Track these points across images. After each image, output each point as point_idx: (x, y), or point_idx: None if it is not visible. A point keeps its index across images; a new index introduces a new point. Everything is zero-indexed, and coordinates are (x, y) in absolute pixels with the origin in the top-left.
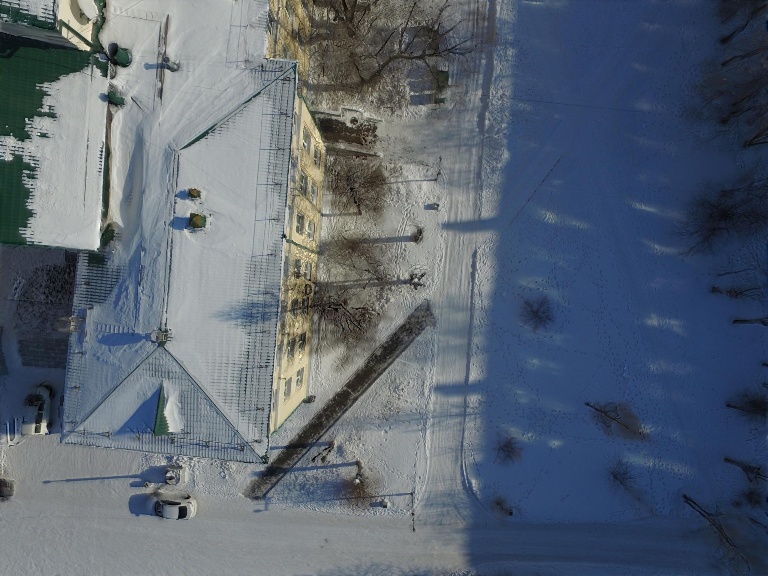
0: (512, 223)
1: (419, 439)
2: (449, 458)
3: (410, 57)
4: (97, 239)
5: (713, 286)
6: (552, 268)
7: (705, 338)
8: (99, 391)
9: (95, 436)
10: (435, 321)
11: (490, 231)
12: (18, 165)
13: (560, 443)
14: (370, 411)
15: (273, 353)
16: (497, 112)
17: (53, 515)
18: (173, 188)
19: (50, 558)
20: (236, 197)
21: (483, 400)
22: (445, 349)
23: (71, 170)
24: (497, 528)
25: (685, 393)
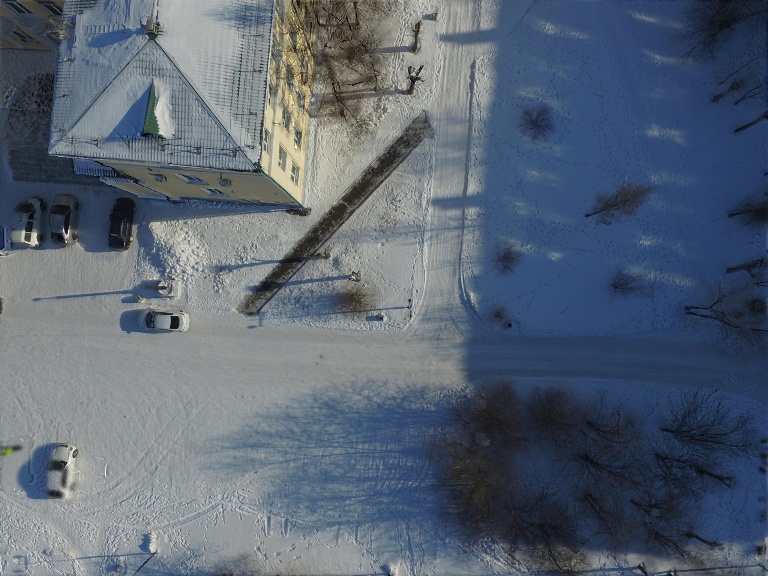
0: (511, 34)
1: (416, 251)
2: (447, 272)
3: None
4: None
5: (714, 95)
6: (551, 78)
7: (706, 148)
8: (88, 95)
9: (83, 145)
10: (433, 133)
11: (489, 42)
12: None
13: (560, 255)
14: (367, 223)
15: (267, 59)
16: None
17: (42, 333)
18: None
19: (39, 377)
20: None
21: (481, 212)
22: (443, 161)
23: None
24: (496, 343)
25: (686, 203)
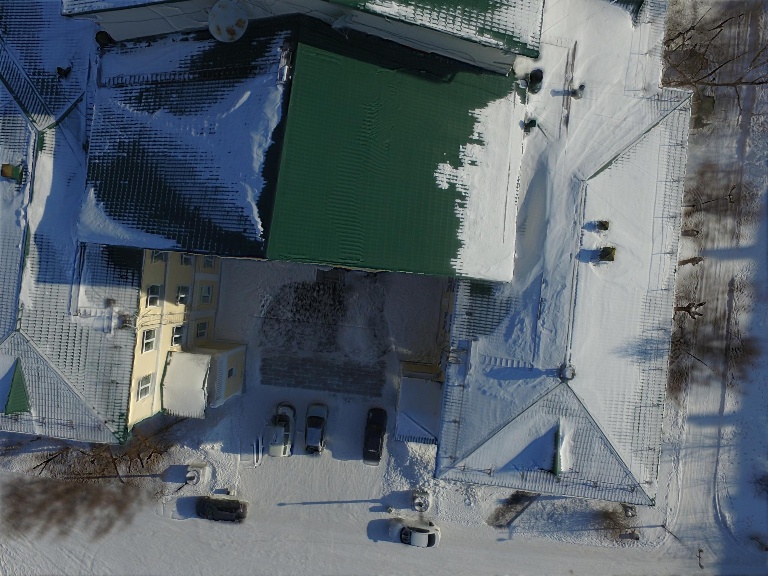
0: None
1: (671, 470)
2: (701, 490)
3: (717, 84)
4: (512, 271)
5: None
6: None
7: None
8: (486, 426)
9: (475, 473)
10: (689, 349)
11: (747, 259)
12: (452, 194)
13: None
14: None
15: (664, 391)
16: (758, 139)
17: (287, 539)
18: (580, 219)
19: None
20: (636, 230)
21: (738, 432)
22: (699, 378)
23: (494, 200)
24: (749, 563)
25: None
